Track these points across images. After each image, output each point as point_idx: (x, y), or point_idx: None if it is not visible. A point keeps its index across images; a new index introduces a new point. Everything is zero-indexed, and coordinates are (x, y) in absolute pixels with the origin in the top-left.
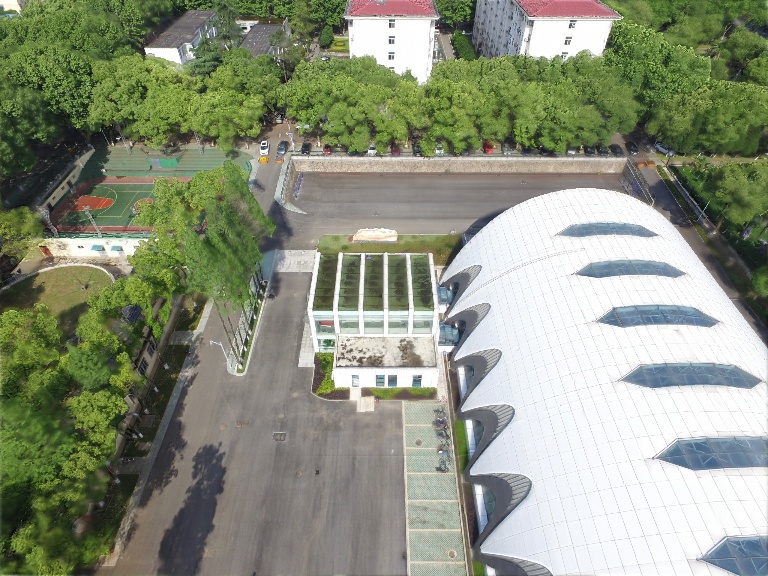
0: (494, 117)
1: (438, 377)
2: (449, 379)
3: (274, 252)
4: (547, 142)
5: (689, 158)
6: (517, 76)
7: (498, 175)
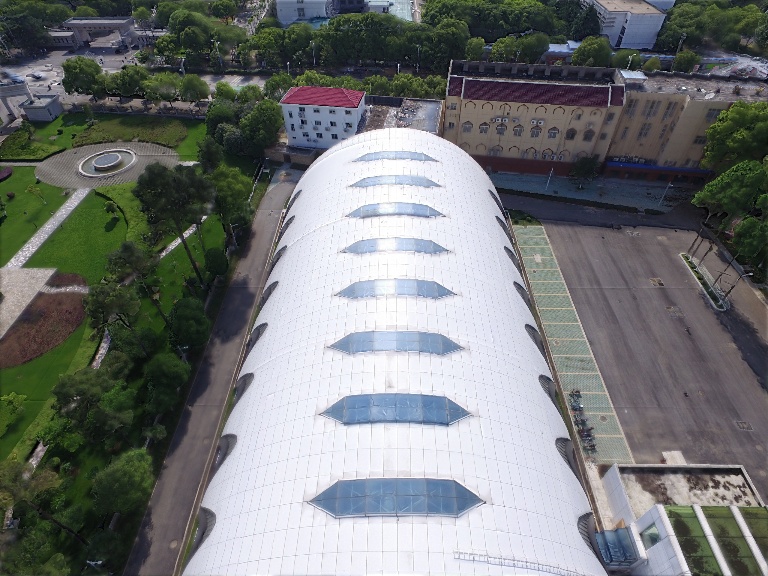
0: None
1: None
2: (588, 494)
3: None
4: None
5: None
6: None
7: None
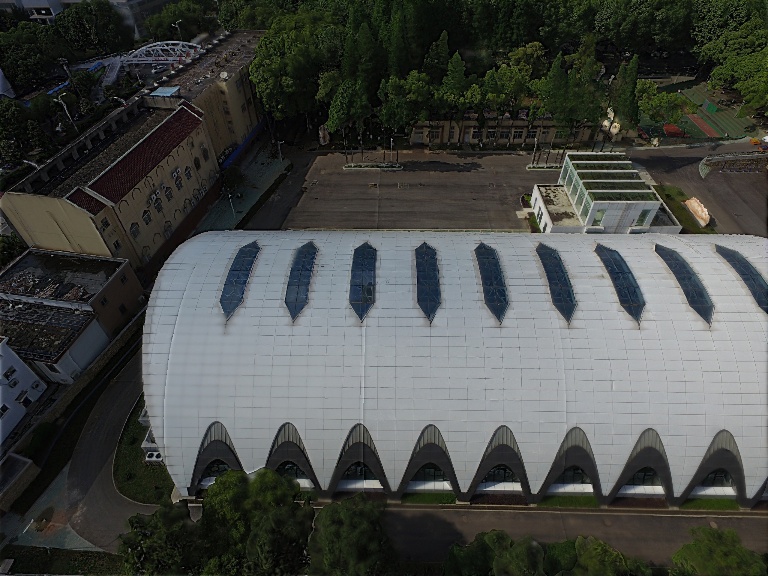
0: None
1: None
2: None
3: (641, 167)
4: None
5: None
6: None
7: None
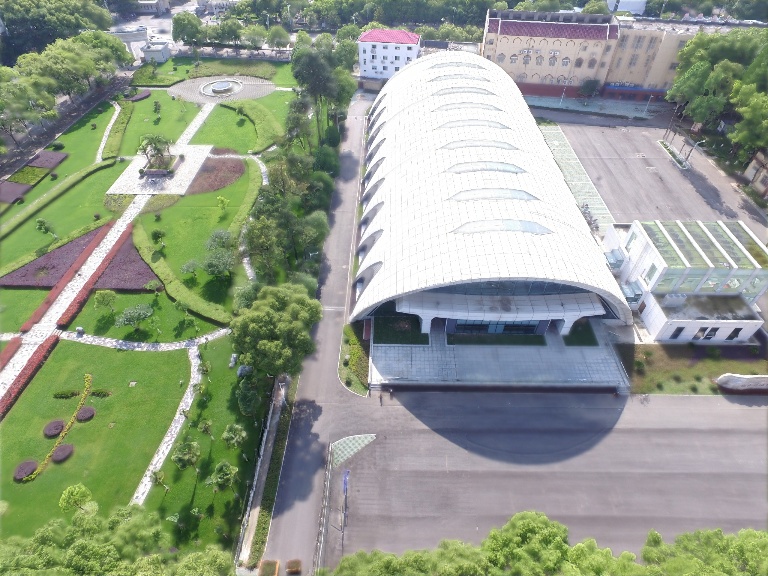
0: None
1: None
2: None
3: None
4: None
5: None
6: None
7: None
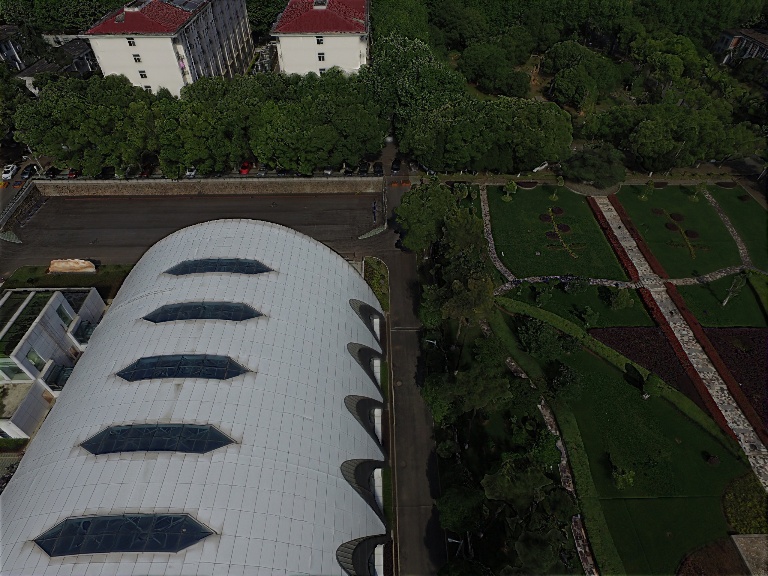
0: (228, 138)
1: (19, 428)
2: None
3: None
4: (287, 163)
5: (450, 176)
6: (261, 94)
7: (252, 197)
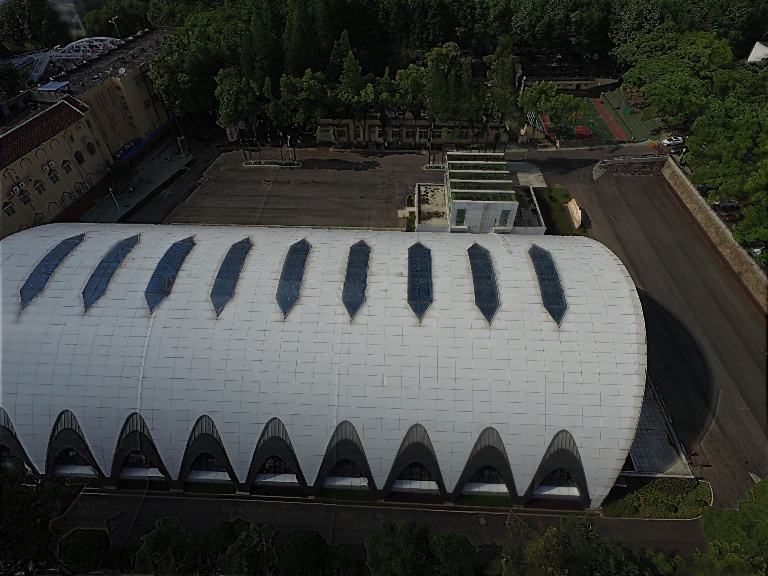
0: None
1: None
2: None
3: (536, 168)
4: None
5: None
6: None
7: None
